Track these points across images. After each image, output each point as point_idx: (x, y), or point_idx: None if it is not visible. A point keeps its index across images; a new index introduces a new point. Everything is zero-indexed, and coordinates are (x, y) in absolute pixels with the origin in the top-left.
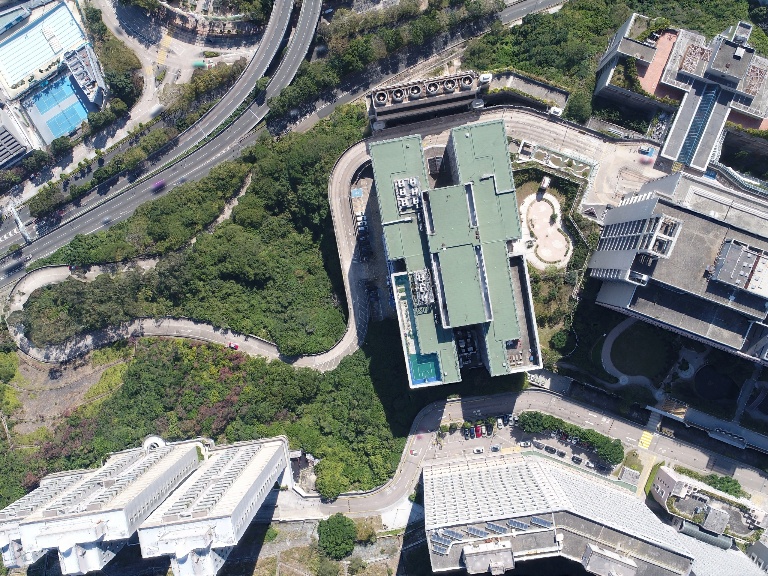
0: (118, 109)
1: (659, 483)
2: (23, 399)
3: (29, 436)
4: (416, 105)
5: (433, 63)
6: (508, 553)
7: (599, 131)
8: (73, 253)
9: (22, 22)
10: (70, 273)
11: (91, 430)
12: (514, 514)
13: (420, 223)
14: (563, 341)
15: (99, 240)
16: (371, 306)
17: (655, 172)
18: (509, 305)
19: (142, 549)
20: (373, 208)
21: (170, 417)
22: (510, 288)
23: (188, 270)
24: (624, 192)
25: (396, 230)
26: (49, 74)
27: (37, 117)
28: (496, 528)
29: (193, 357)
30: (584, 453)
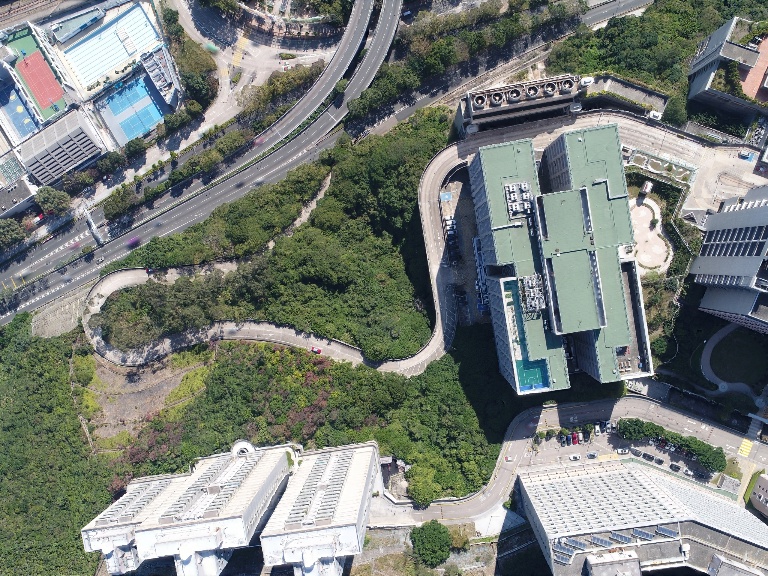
0: (194, 111)
1: (761, 491)
2: (102, 403)
3: (111, 440)
4: (512, 108)
5: (514, 66)
6: (635, 563)
7: (699, 135)
8: (151, 256)
9: (96, 23)
10: (147, 276)
11: (177, 435)
12: (639, 523)
13: (531, 228)
14: (663, 347)
15: (175, 243)
16: (459, 311)
17: (755, 177)
18: (620, 311)
19: (264, 557)
20: (462, 212)
21: (259, 422)
22: (621, 294)
23: (270, 273)
24: (723, 197)
25: (506, 235)
26: (123, 75)
27: (110, 119)
28: (621, 538)
29: (277, 361)
30: (682, 461)
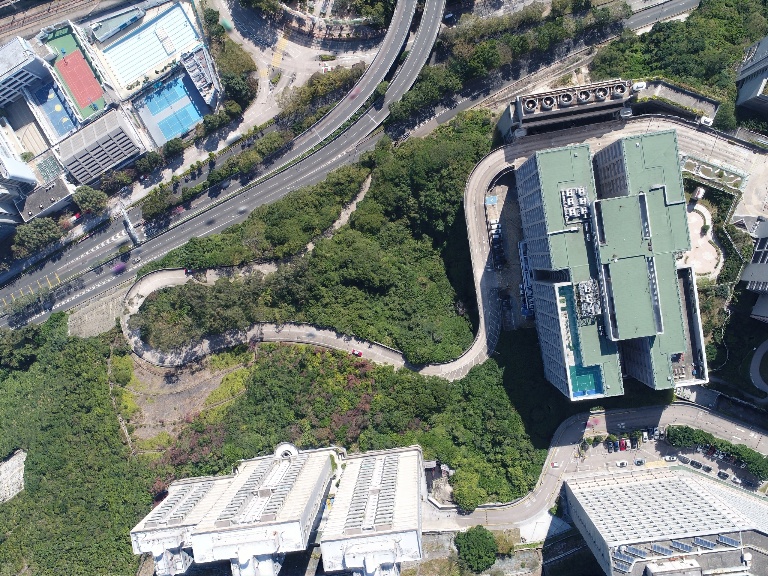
0: (234, 112)
1: None
2: (141, 403)
3: (151, 441)
4: (562, 113)
5: (556, 70)
6: (697, 572)
7: (750, 142)
8: (191, 256)
9: (136, 23)
10: (186, 276)
11: (219, 436)
12: (700, 532)
13: (587, 233)
14: (713, 354)
15: (214, 243)
16: (503, 315)
17: None
18: (676, 318)
19: (324, 562)
20: (508, 216)
21: (303, 425)
22: (677, 301)
23: (311, 275)
24: None
25: (561, 240)
26: (162, 75)
27: (148, 118)
28: (681, 546)
29: (318, 364)
30: (730, 468)
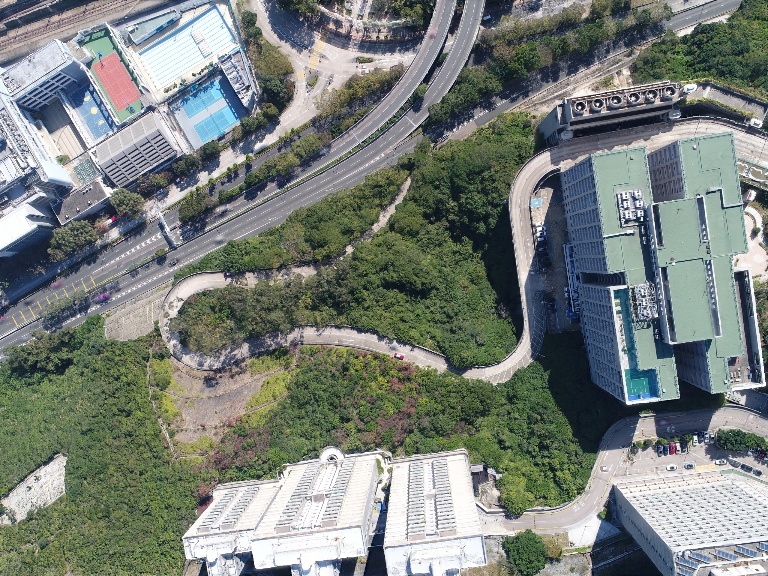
0: (271, 114)
1: None
2: (181, 407)
3: (192, 445)
4: (610, 115)
5: (596, 72)
6: None
7: None
8: (230, 259)
9: (172, 25)
10: (224, 279)
11: (264, 440)
12: (765, 537)
13: (643, 236)
14: (764, 357)
15: (252, 246)
16: (548, 318)
17: None
18: (732, 321)
19: None
20: (552, 218)
21: (349, 429)
22: (734, 304)
23: (353, 278)
24: None
25: (617, 243)
26: (198, 78)
27: (184, 121)
28: (746, 551)
29: (361, 367)
30: None
